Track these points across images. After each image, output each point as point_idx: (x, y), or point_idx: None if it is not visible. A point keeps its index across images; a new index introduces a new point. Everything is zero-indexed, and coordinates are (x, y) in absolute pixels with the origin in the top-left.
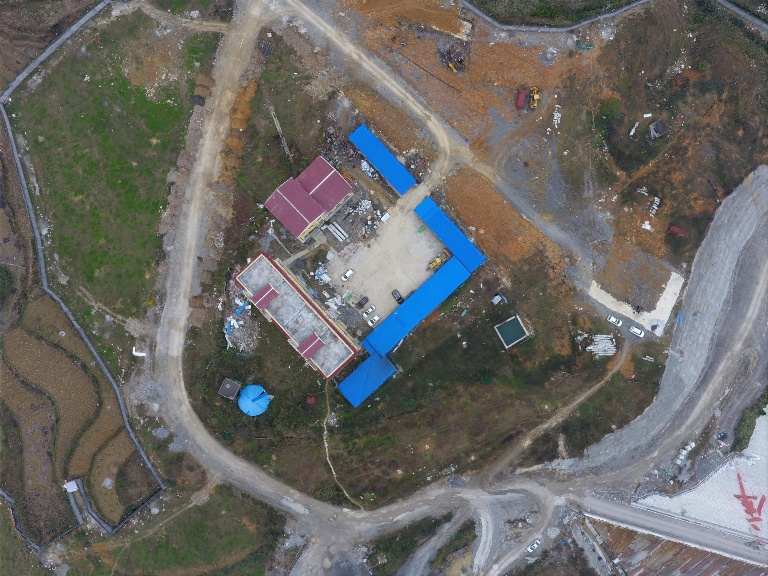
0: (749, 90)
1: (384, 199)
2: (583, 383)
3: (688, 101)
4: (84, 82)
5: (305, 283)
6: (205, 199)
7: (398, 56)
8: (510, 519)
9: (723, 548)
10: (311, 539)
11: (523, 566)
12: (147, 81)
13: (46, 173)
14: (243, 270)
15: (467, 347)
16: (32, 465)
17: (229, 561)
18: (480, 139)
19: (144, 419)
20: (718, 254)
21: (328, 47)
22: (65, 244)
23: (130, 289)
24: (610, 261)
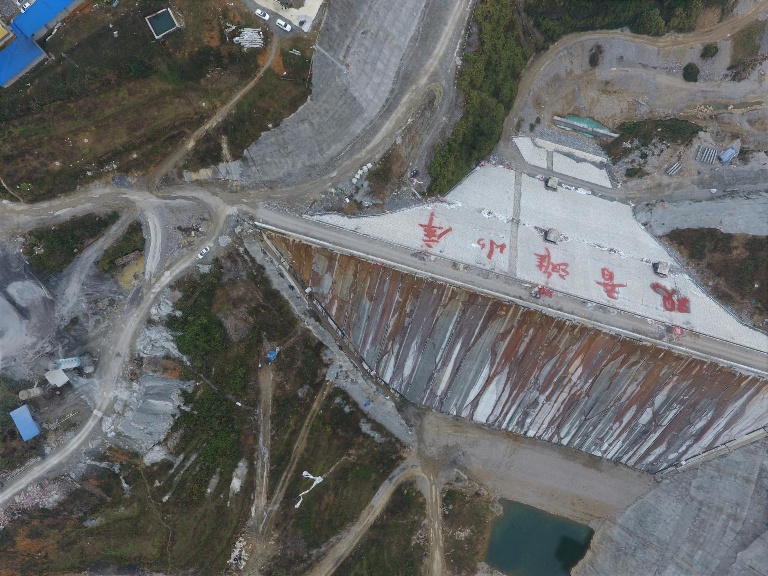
0: None
1: None
2: (238, 81)
3: None
4: None
5: None
6: None
7: None
8: (181, 226)
9: (390, 259)
10: None
11: (196, 275)
12: None
13: None
14: None
15: (117, 36)
16: None
17: None
18: None
19: None
20: None
21: None
22: None
23: None
24: None
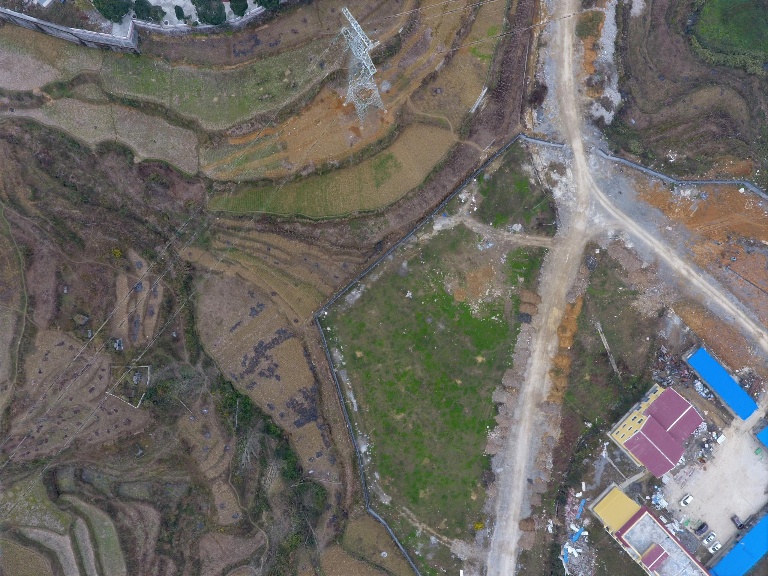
0: None
1: (718, 420)
2: None
3: None
4: (406, 298)
5: None
6: (534, 420)
7: (728, 272)
8: None
9: None
10: None
11: None
12: (471, 297)
13: (365, 389)
14: (628, 528)
15: None
16: None
17: None
18: None
19: None
20: None
21: (656, 263)
22: (387, 463)
23: (455, 509)
24: None
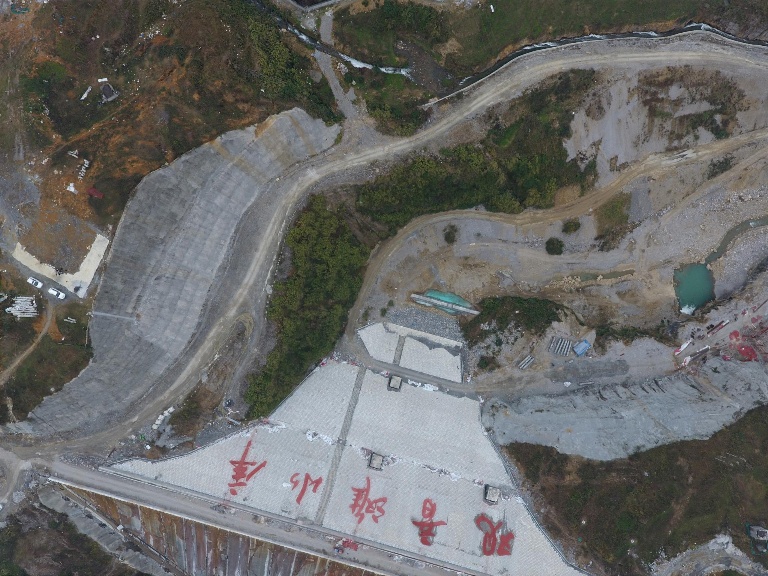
0: (217, 55)
1: None
2: (17, 346)
3: (146, 66)
4: None
5: None
6: None
7: None
8: None
9: (189, 512)
10: None
11: None
12: None
13: None
14: None
15: None
16: None
17: None
18: None
19: None
20: (190, 219)
21: None
22: None
23: None
24: (36, 223)
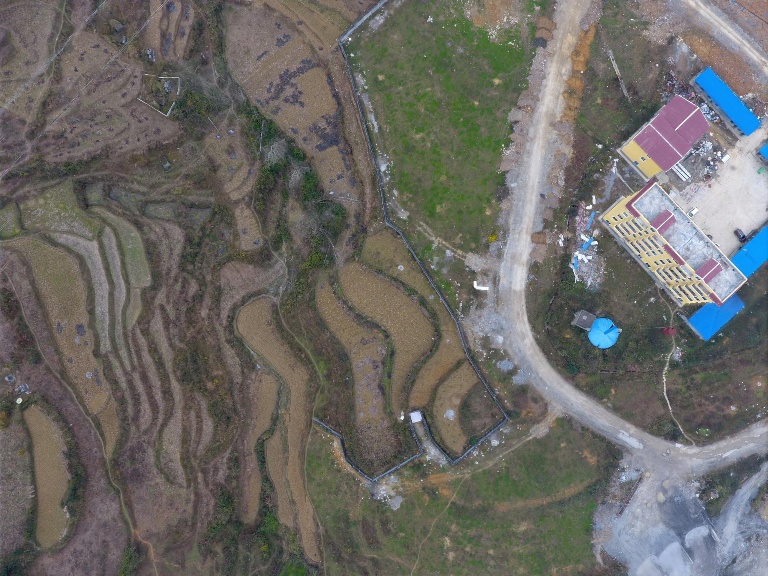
0: None
1: (723, 141)
2: None
3: None
4: (427, 23)
5: None
6: (548, 138)
7: (734, 4)
8: None
9: None
10: (645, 473)
11: None
12: (489, 23)
13: (386, 111)
14: (638, 197)
15: None
16: (363, 398)
17: (567, 494)
18: None
19: (489, 351)
20: None
21: None
22: (405, 180)
23: (470, 225)
24: None
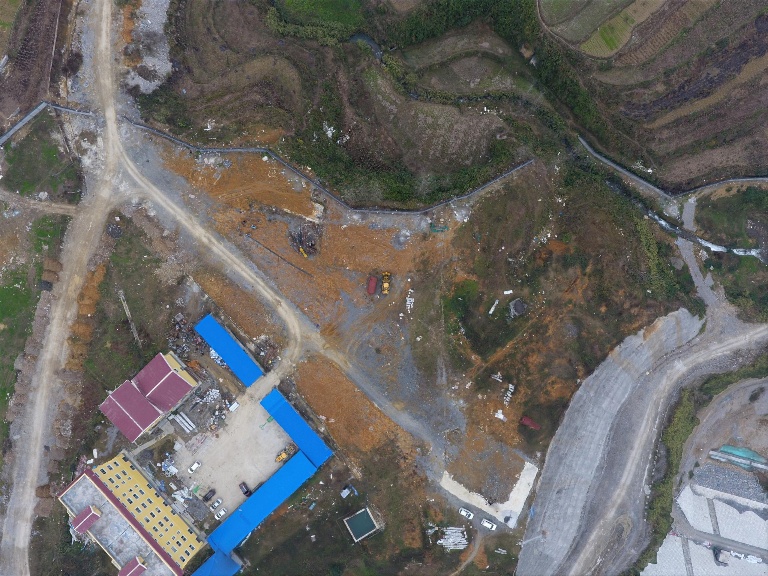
0: (615, 261)
1: (233, 387)
2: (438, 572)
3: (550, 276)
4: None
5: (152, 475)
6: (52, 387)
7: (248, 240)
8: None
9: None
10: None
11: None
12: None
13: None
14: (66, 490)
15: (315, 541)
16: None
17: None
18: (331, 325)
19: None
20: (585, 427)
21: (177, 230)
22: None
23: None
24: (463, 451)
